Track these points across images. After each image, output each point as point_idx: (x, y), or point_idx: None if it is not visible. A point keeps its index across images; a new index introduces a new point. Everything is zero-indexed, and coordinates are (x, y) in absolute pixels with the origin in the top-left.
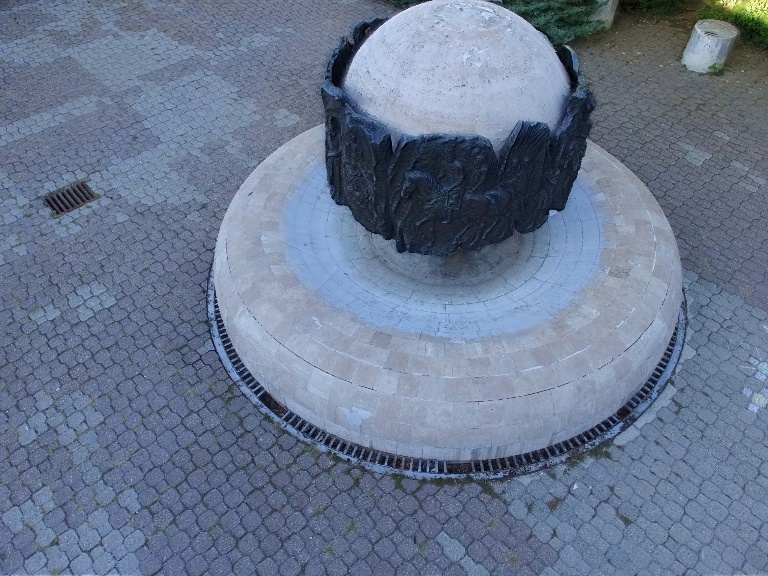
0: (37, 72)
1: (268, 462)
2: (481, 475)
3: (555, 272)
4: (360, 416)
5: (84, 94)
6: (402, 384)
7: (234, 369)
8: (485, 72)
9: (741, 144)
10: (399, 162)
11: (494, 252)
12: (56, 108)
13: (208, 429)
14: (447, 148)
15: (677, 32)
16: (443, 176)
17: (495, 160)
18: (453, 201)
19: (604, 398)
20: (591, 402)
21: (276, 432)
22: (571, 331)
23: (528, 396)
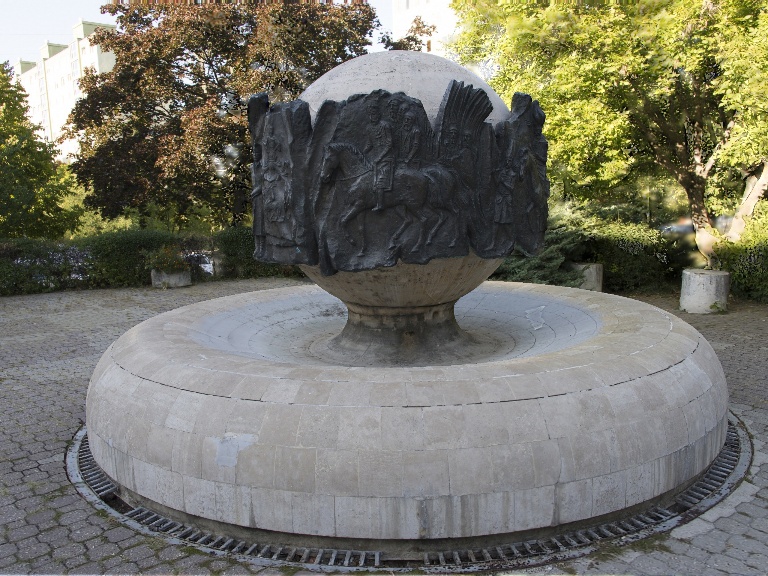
0: (0, 323)
1: (74, 554)
2: (439, 568)
3: (542, 349)
4: (236, 446)
5: (39, 332)
6: (305, 390)
7: (80, 474)
8: (415, 65)
9: (767, 340)
10: (318, 133)
11: (463, 349)
12: (3, 338)
13: (0, 523)
14: (370, 104)
15: (670, 299)
16: (369, 148)
17: (428, 124)
18: (383, 176)
19: (630, 433)
20: (609, 432)
21: (107, 525)
22: (563, 355)
23: (501, 403)
